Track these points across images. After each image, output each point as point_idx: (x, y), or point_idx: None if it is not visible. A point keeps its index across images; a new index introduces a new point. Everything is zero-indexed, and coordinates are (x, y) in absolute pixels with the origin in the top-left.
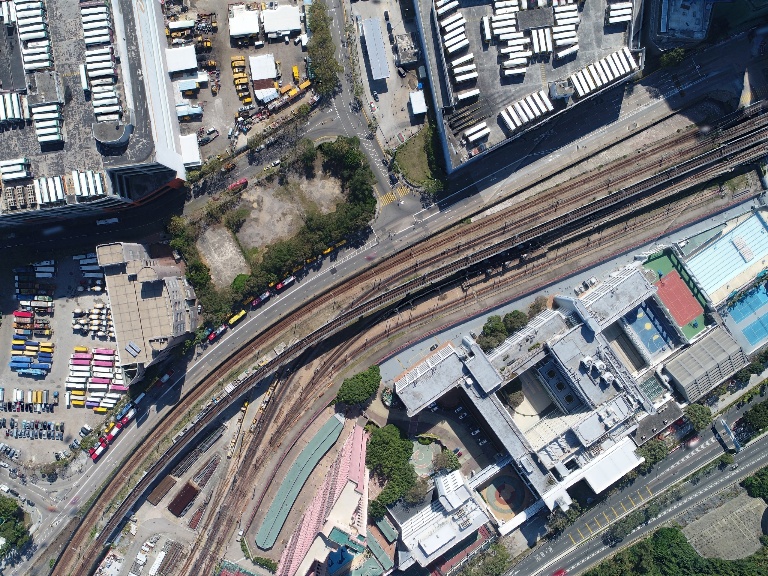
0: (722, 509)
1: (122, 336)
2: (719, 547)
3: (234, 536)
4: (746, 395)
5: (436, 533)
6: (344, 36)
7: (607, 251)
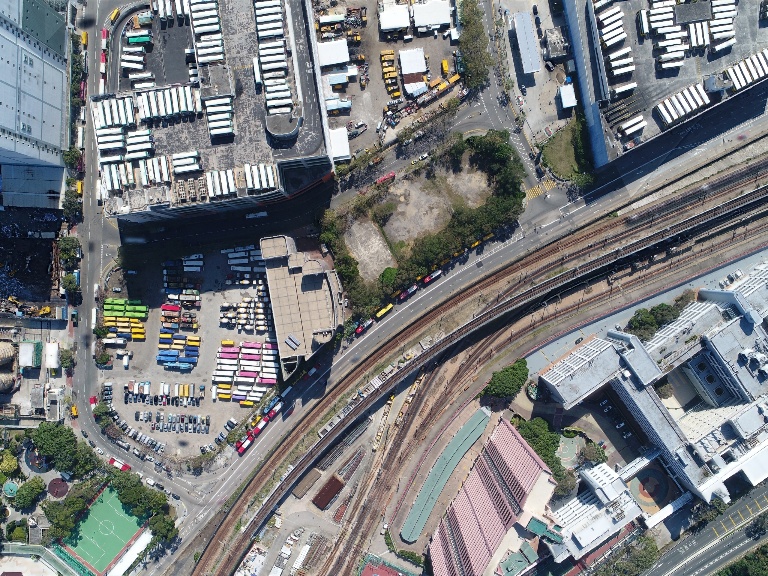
0: None
1: (282, 329)
2: None
3: (378, 529)
4: None
5: (591, 525)
6: (492, 30)
7: (752, 244)
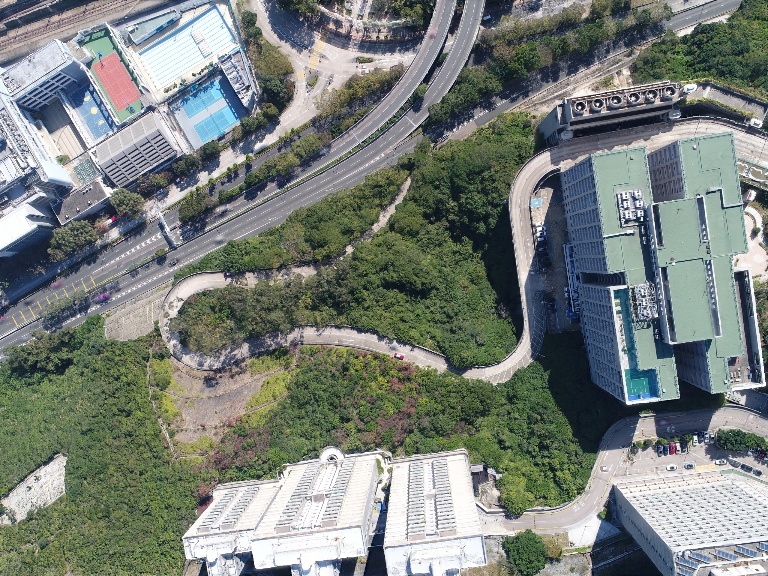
0: (146, 300)
1: None
2: (123, 331)
3: None
4: (193, 193)
5: None
6: None
7: (66, 34)
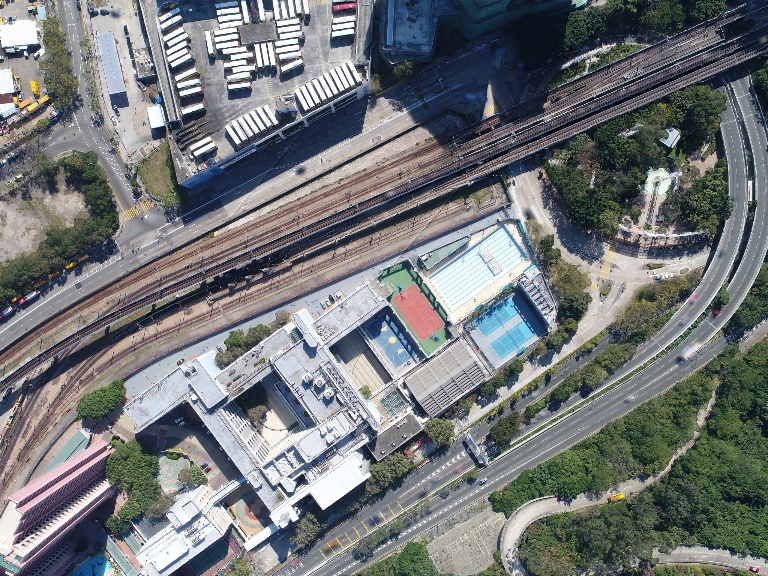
0: (466, 524)
1: None
2: (456, 563)
3: None
4: None
5: (166, 549)
6: (84, 50)
7: (353, 265)
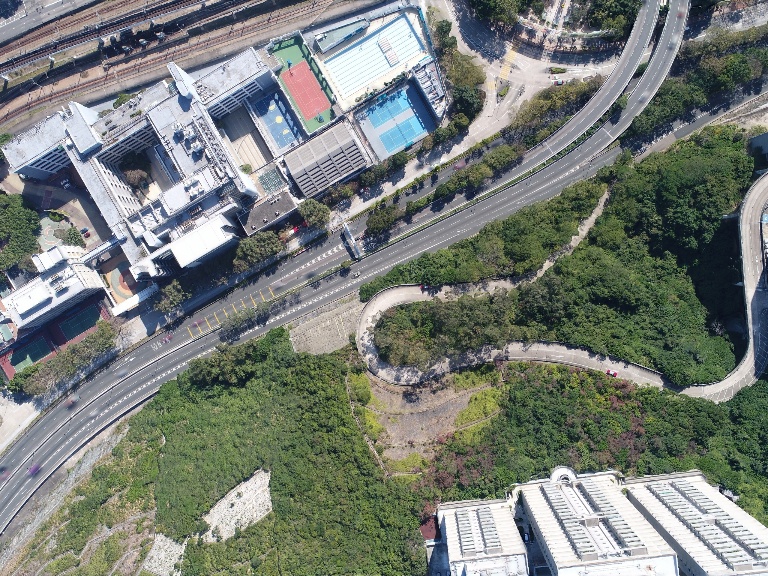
0: (331, 312)
1: None
2: (313, 344)
3: None
4: (378, 203)
5: (29, 293)
6: None
7: (249, 42)
